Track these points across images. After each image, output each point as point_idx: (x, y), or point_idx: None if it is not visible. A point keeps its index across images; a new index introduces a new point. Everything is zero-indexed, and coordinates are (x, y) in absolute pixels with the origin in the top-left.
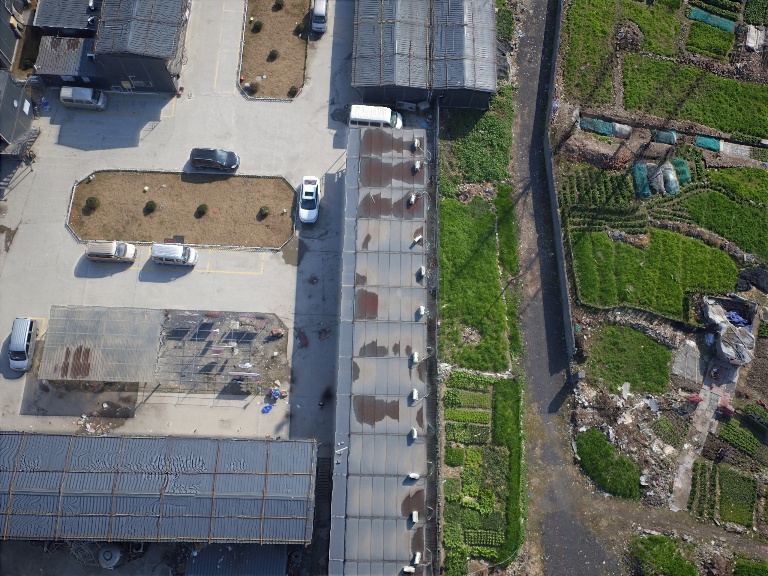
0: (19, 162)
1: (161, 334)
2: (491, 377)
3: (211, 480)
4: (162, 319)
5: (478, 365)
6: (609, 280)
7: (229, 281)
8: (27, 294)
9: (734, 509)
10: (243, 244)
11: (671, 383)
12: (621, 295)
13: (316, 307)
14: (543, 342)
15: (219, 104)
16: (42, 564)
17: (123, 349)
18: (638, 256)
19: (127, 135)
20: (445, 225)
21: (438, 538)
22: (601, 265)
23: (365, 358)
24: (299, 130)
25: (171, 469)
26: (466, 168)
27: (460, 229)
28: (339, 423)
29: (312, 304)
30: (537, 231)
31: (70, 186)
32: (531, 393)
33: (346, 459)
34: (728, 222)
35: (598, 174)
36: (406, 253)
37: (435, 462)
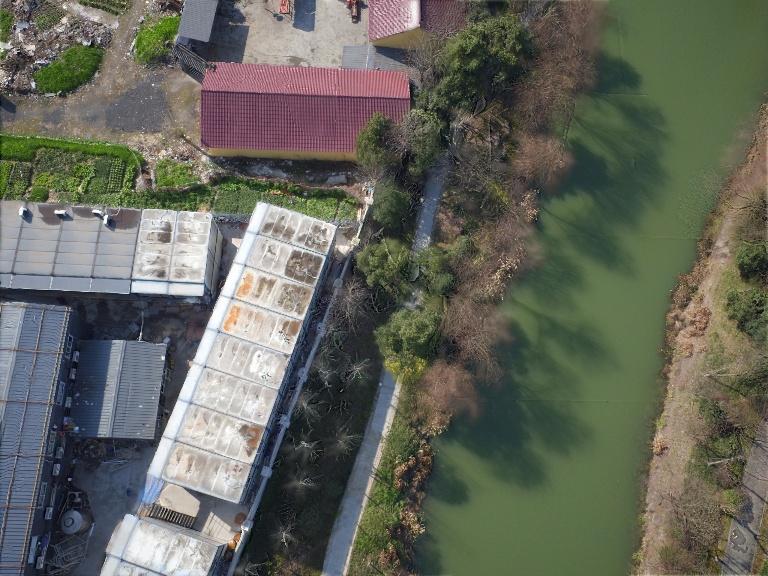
0: None
1: None
2: None
3: None
4: None
5: None
6: None
7: None
8: None
9: None
10: None
11: (6, 9)
12: None
13: None
14: None
15: None
16: None
17: None
18: None
19: None
20: None
21: None
22: None
23: None
24: None
25: None
26: None
27: None
28: None
29: None
30: None
31: None
32: None
33: None
34: None
35: None
36: None
37: None
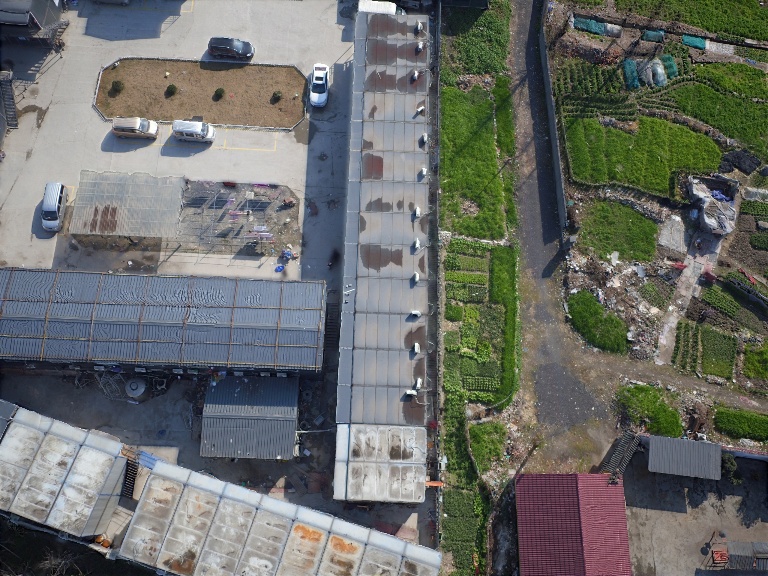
0: (49, 50)
1: (182, 198)
2: (488, 244)
3: (230, 313)
4: (183, 185)
5: (476, 233)
6: (600, 160)
7: (245, 157)
8: (57, 165)
9: (715, 363)
10: (258, 125)
11: (657, 253)
12: (611, 174)
13: (325, 181)
14: (537, 215)
15: (235, 1)
16: (73, 399)
17: (147, 208)
18: (627, 140)
19: (149, 27)
20: (446, 110)
21: (438, 383)
22: (592, 147)
23: (371, 213)
24: (310, 25)
25: (193, 300)
26: (466, 60)
27: (460, 113)
28: (347, 268)
29: (322, 178)
30: (533, 118)
31: (97, 72)
32: (526, 260)
33: (353, 299)
34: (712, 110)
35: (590, 68)
36: (409, 122)
37: (436, 317)
